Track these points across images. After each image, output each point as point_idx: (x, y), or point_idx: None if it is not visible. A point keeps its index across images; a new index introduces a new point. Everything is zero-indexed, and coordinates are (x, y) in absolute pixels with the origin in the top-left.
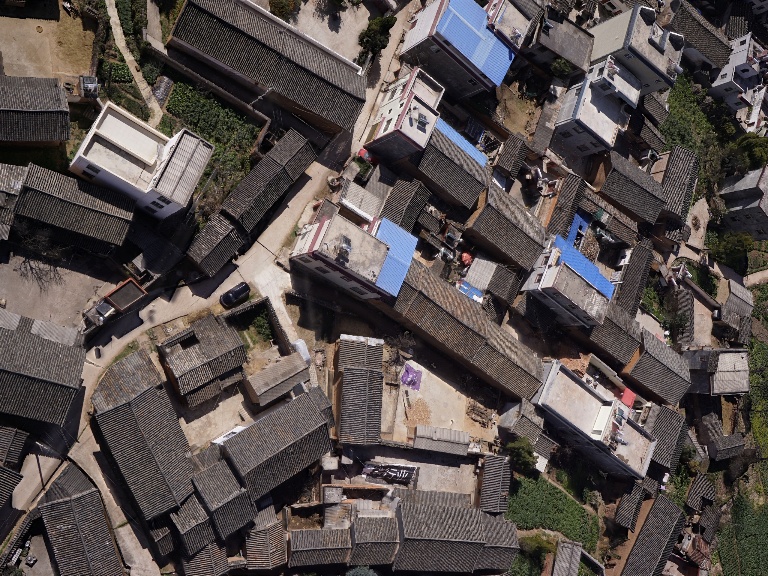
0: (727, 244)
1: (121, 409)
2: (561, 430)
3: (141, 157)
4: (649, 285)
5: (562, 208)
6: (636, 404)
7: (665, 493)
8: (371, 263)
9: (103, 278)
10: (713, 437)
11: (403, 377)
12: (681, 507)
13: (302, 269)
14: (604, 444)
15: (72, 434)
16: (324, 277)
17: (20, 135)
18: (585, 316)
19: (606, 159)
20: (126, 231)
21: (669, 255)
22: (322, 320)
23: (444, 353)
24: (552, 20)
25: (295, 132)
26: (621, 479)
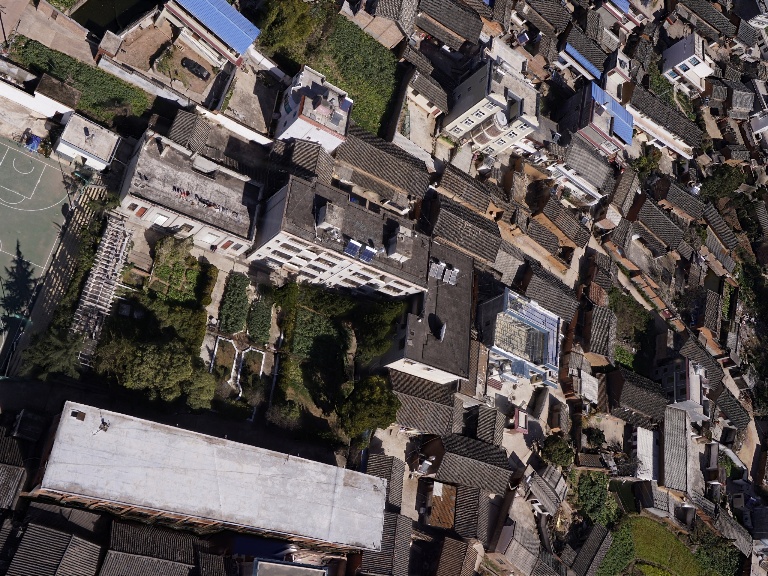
0: None
1: None
2: None
3: None
4: None
5: (509, 8)
6: None
7: None
8: None
9: None
10: None
11: None
12: None
13: None
14: None
15: None
16: None
17: None
18: None
19: None
20: None
21: None
22: None
23: None
24: None
25: None
26: None
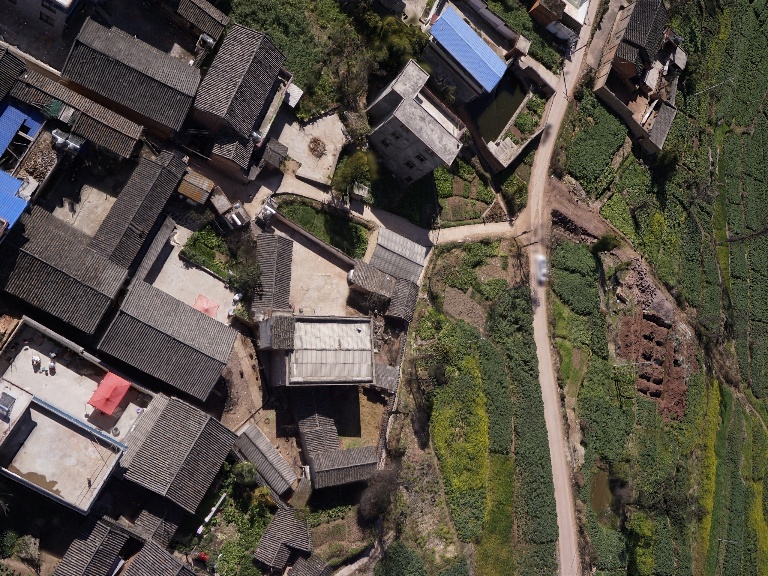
0: (344, 169)
1: None
2: None
3: None
4: (206, 227)
5: None
6: (145, 399)
7: (215, 539)
8: None
9: None
10: (314, 452)
11: None
12: (248, 561)
13: None
14: None
15: None
16: None
17: None
18: None
19: None
20: None
21: (258, 188)
22: None
23: None
24: None
25: None
26: None
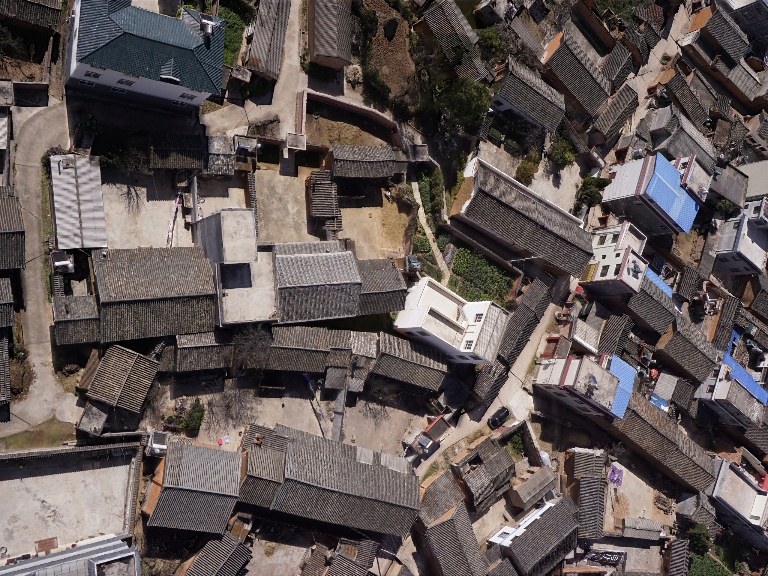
0: None
1: (446, 524)
2: (722, 513)
3: (458, 324)
4: None
5: (724, 326)
6: None
7: None
8: (608, 394)
9: (414, 412)
10: None
11: (610, 476)
12: None
13: (541, 392)
14: (762, 528)
15: (399, 539)
16: (556, 398)
17: (374, 310)
18: (747, 421)
19: (753, 279)
20: (442, 380)
21: None
22: (558, 434)
23: (638, 454)
24: (718, 167)
25: (539, 281)
26: (762, 551)
